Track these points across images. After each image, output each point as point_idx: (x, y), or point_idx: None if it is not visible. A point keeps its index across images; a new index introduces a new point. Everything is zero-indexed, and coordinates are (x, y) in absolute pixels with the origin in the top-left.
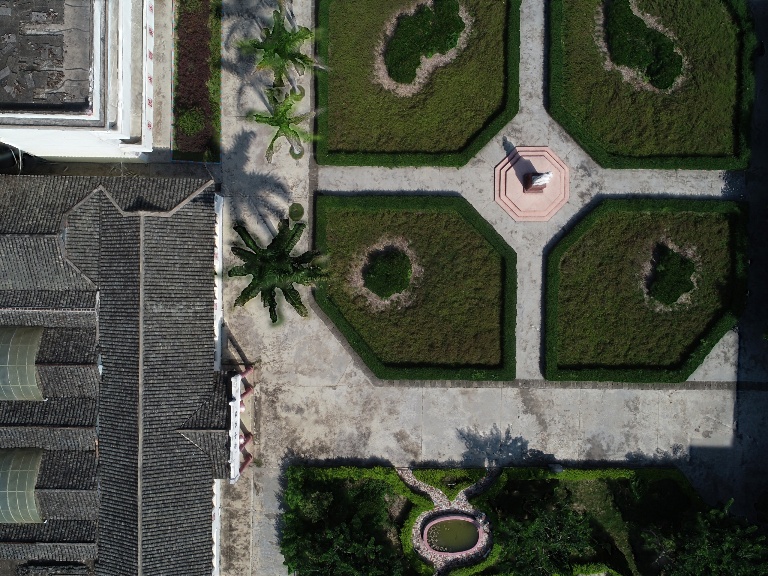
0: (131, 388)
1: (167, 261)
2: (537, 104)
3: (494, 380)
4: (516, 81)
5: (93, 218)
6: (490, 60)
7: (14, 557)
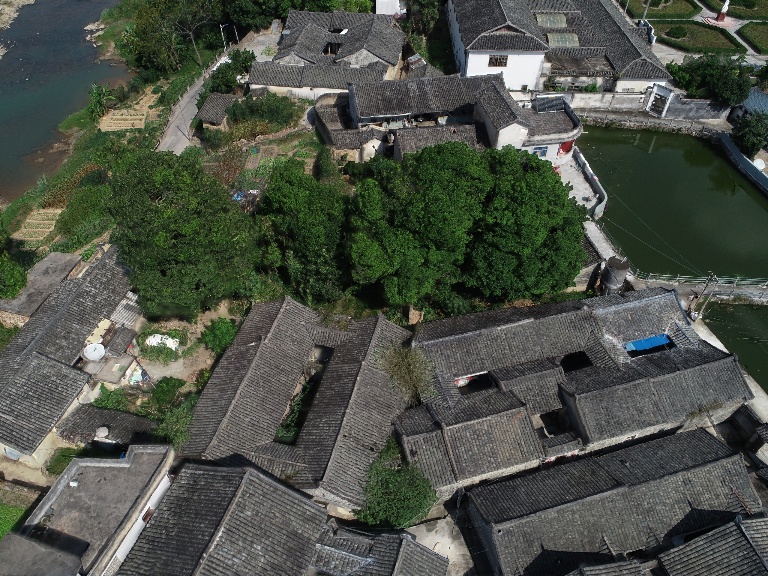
0: (605, 17)
1: (604, 2)
2: (707, 11)
3: (739, 51)
4: (697, 4)
5: (570, 0)
6: (684, 3)
7: (569, 54)
